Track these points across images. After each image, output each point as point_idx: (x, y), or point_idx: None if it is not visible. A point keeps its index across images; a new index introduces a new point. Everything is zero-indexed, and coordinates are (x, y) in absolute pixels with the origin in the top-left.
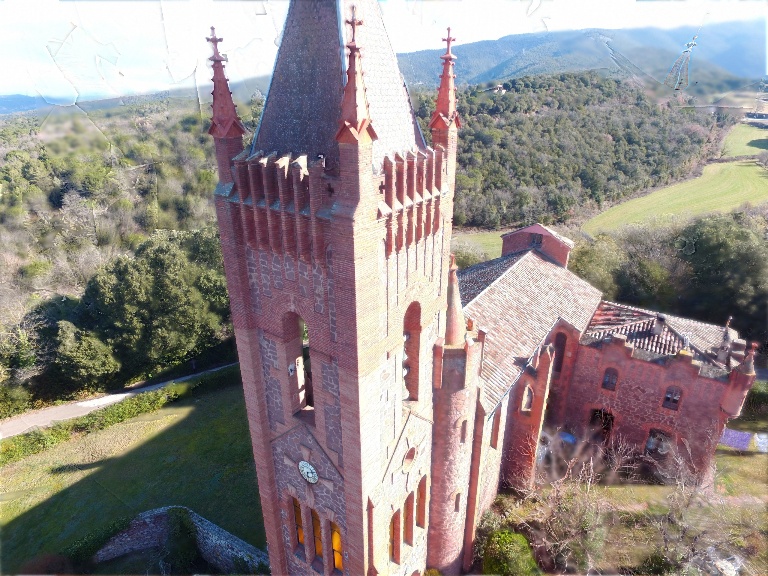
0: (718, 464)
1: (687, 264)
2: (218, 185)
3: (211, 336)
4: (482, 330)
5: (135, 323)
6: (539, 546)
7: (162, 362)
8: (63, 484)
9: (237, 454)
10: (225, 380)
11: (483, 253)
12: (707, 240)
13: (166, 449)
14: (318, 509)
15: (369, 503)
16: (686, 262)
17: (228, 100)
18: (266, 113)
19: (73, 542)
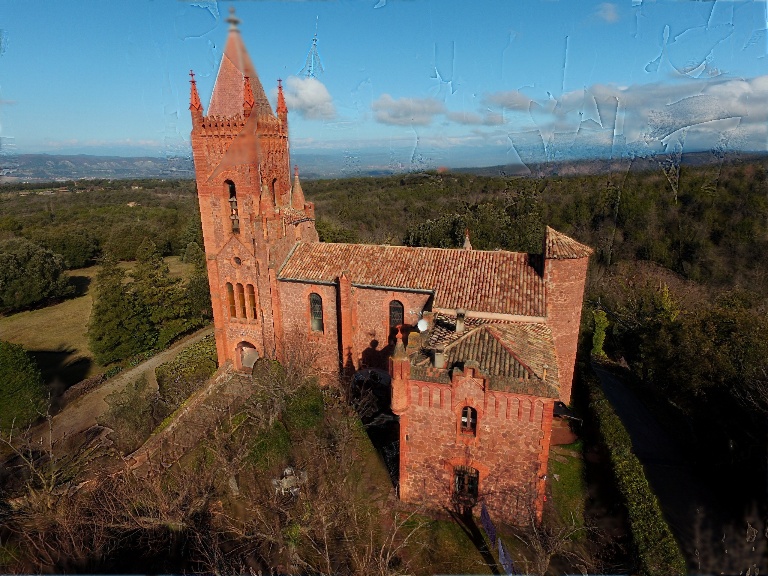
0: (448, 523)
1: None
2: None
3: None
4: (262, 212)
5: None
6: None
7: None
8: None
9: None
10: None
11: None
12: None
13: None
14: None
15: None
16: None
17: None
18: None
19: None
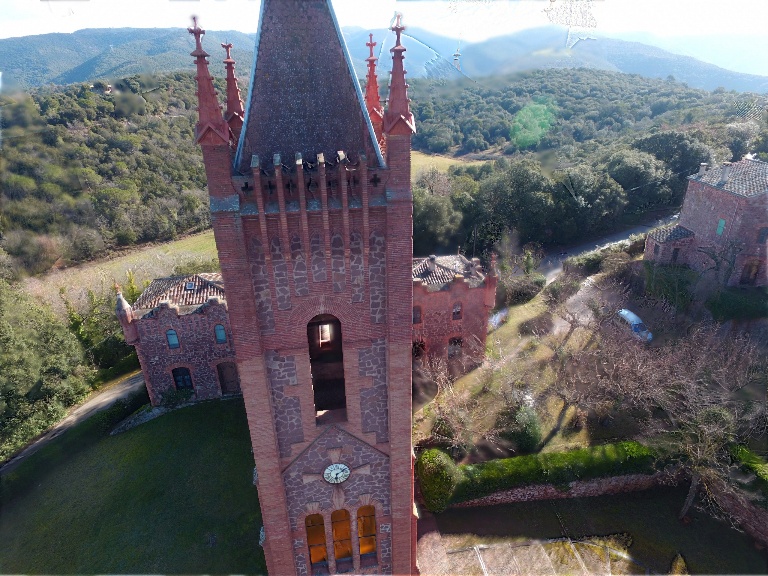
0: None
1: None
2: (213, 201)
3: None
4: None
5: None
6: (454, 445)
7: None
8: None
9: None
10: None
11: (209, 260)
12: None
13: None
14: (349, 504)
15: None
16: None
17: None
18: (252, 114)
19: None
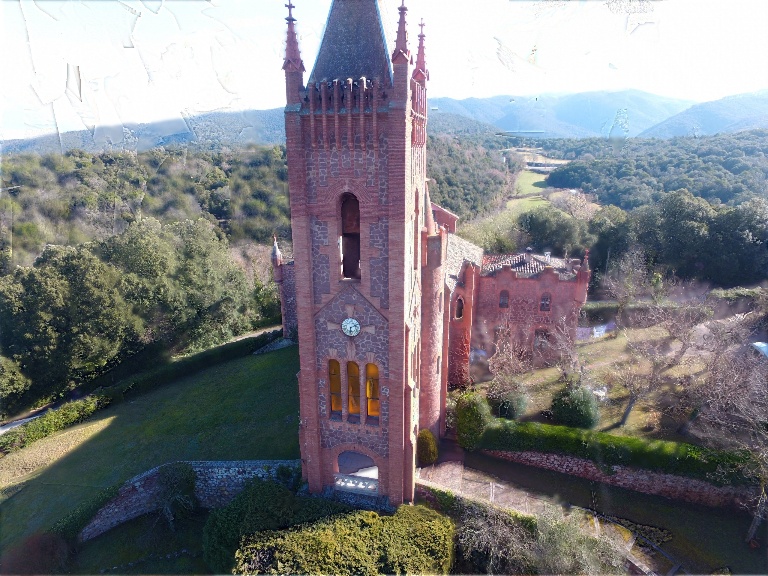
0: None
1: (528, 235)
2: (287, 106)
3: (131, 344)
4: None
5: (50, 332)
6: (493, 392)
7: (76, 377)
8: (0, 498)
9: (205, 423)
10: (158, 380)
11: None
12: (536, 219)
13: (120, 440)
14: (358, 358)
15: (406, 328)
16: (527, 234)
17: (296, 47)
18: (320, 58)
19: (56, 522)
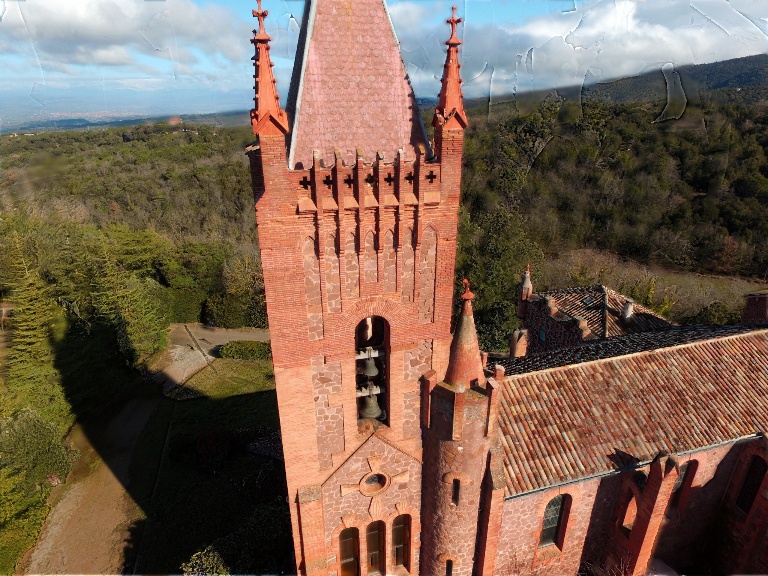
0: None
1: None
2: None
3: None
4: (490, 382)
5: None
6: None
7: None
8: (265, 387)
9: None
10: None
11: None
12: None
13: None
14: None
15: (298, 496)
16: None
17: None
18: None
19: (239, 427)
